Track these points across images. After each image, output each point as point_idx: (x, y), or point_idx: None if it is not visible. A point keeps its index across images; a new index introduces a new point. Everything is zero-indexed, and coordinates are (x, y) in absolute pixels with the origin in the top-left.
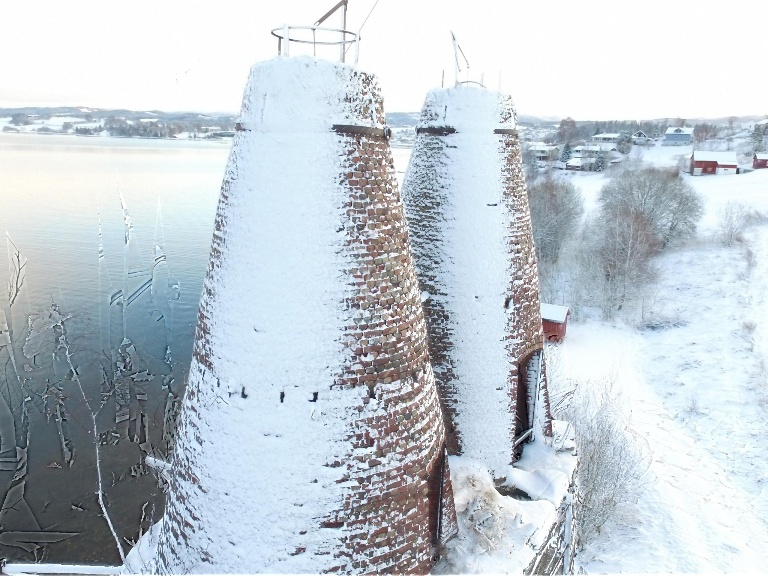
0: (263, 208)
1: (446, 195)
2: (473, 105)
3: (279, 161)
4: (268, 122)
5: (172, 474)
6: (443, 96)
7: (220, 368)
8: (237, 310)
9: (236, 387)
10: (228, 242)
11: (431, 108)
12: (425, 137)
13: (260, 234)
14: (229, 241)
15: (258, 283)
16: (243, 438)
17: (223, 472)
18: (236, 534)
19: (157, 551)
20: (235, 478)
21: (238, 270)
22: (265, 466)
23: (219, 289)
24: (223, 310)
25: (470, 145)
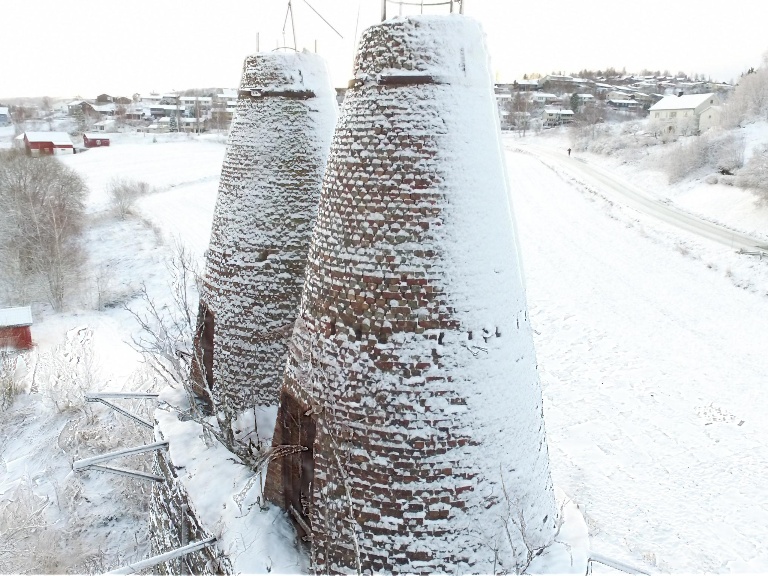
0: (483, 158)
1: (320, 157)
2: (324, 71)
3: (485, 114)
4: (472, 77)
5: (400, 468)
6: (295, 60)
7: (471, 320)
8: (478, 259)
9: (492, 330)
10: (452, 196)
11: (283, 71)
12: (281, 101)
13: (485, 183)
14: (453, 195)
15: (491, 229)
16: (506, 372)
17: (497, 412)
18: (514, 460)
19: (382, 569)
20: (507, 411)
21: (471, 221)
22: (522, 387)
23: (449, 246)
24: (461, 264)
25: (329, 109)
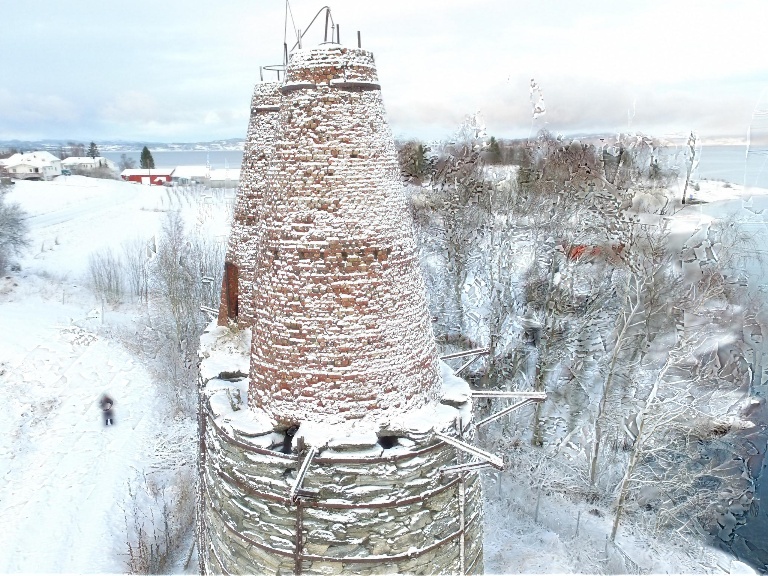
0: None
1: None
2: None
3: None
4: None
5: None
6: None
7: None
8: None
9: None
10: None
11: None
12: None
13: None
14: None
15: None
16: None
17: None
18: None
19: None
20: None
21: None
22: None
23: None
24: None
25: None
